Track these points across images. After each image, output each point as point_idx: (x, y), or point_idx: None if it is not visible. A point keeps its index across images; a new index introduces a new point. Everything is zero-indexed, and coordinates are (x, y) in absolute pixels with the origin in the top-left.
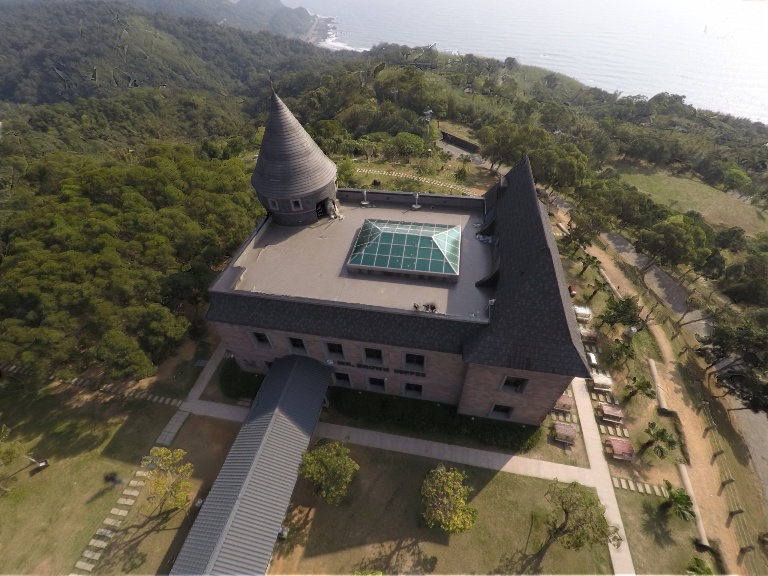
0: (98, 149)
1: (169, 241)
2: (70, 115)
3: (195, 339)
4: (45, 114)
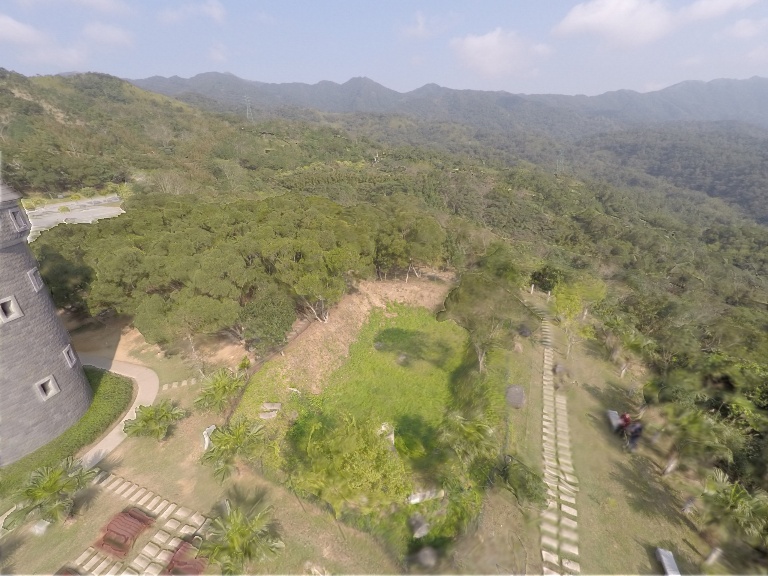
0: (725, 276)
1: (135, 246)
2: (756, 241)
3: (78, 329)
4: (728, 230)
